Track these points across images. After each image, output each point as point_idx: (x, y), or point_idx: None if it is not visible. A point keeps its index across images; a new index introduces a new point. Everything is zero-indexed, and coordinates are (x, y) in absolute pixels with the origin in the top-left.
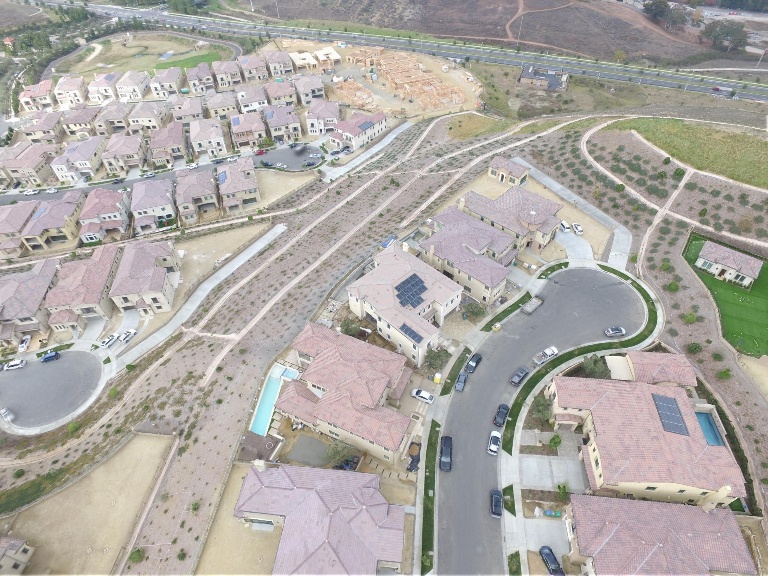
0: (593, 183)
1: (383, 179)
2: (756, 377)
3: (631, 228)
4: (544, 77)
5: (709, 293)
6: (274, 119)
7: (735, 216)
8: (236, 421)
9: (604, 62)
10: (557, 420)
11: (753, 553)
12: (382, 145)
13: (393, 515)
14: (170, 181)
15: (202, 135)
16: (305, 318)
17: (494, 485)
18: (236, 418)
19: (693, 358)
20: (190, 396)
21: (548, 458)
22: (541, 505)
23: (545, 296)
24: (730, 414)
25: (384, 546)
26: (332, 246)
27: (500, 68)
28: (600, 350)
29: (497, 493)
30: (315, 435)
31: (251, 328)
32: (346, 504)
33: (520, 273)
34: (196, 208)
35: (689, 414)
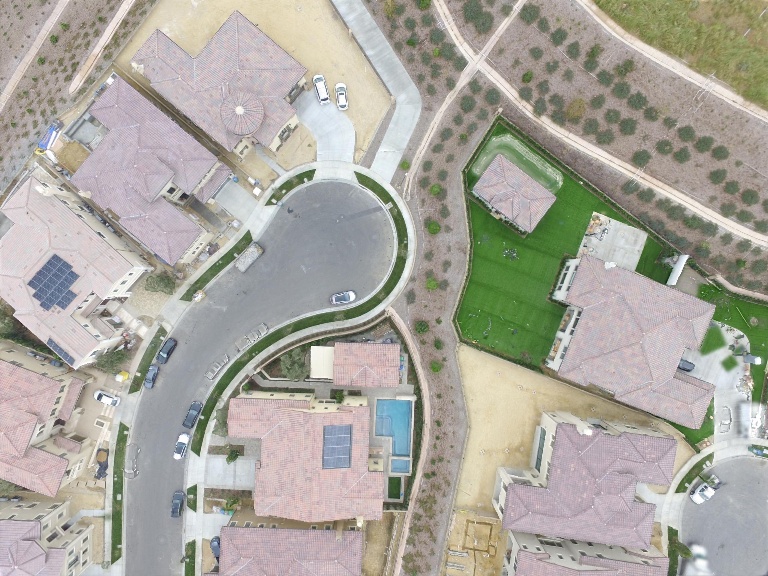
0: None
1: None
2: (469, 369)
3: (424, 92)
4: None
5: (468, 247)
6: None
7: (569, 90)
8: None
9: None
10: None
11: (392, 529)
12: None
13: (51, 562)
14: None
15: None
16: None
17: (179, 485)
18: None
19: (418, 337)
20: None
21: None
22: (220, 502)
23: (270, 238)
24: (428, 405)
25: None
26: None
27: None
28: (319, 324)
29: (178, 497)
30: None
31: None
32: (1, 562)
33: (242, 196)
34: None
35: (361, 440)
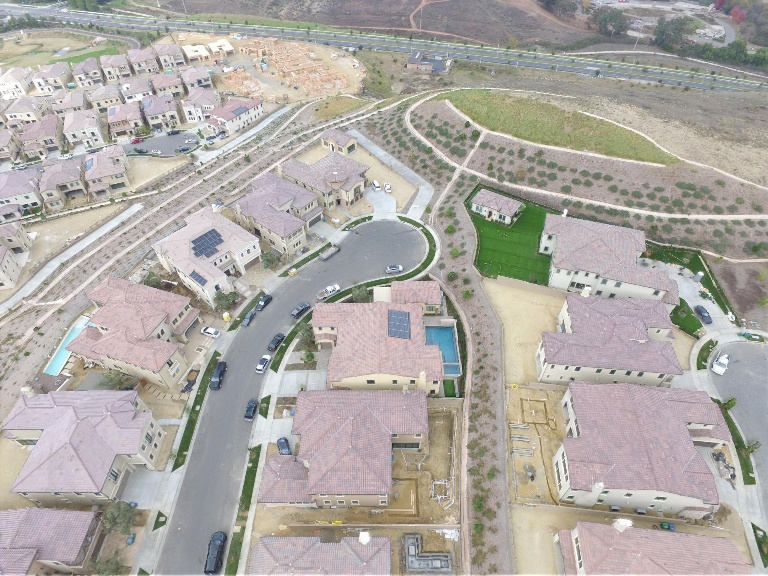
0: (410, 148)
1: (243, 158)
2: (492, 294)
3: (435, 184)
4: (428, 62)
5: (475, 231)
6: (151, 108)
7: (514, 168)
8: (34, 367)
9: (489, 47)
10: (315, 339)
11: (453, 426)
12: (258, 129)
13: (138, 419)
14: (36, 170)
15: (75, 126)
16: (120, 277)
17: (255, 397)
18: (35, 364)
19: (451, 285)
20: (5, 354)
21: (307, 372)
22: (290, 408)
23: (344, 245)
24: (467, 325)
25: (123, 443)
26: (170, 217)
27: (391, 55)
28: (378, 285)
29: (253, 402)
30: (104, 371)
31: (77, 292)
32: (95, 413)
33: (327, 227)
34: (63, 195)
35: (417, 323)
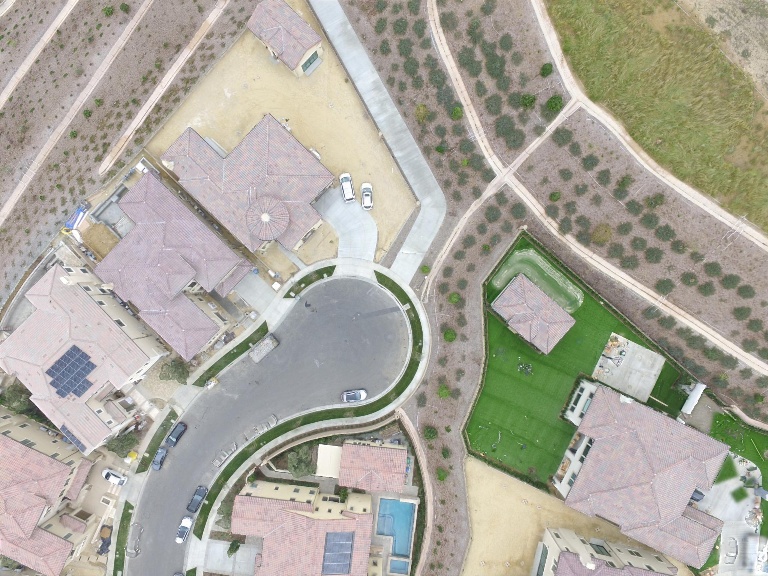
0: (423, 85)
1: None
2: (475, 480)
3: (450, 197)
4: None
5: (483, 360)
6: None
7: (596, 214)
8: None
9: None
10: None
11: None
12: None
13: None
14: None
15: None
16: None
17: (179, 567)
18: None
19: (426, 441)
20: None
21: None
22: None
23: (286, 330)
24: (431, 510)
25: None
26: (17, 184)
27: None
28: (328, 419)
29: None
30: None
31: None
32: None
33: (261, 287)
34: None
35: (362, 547)
